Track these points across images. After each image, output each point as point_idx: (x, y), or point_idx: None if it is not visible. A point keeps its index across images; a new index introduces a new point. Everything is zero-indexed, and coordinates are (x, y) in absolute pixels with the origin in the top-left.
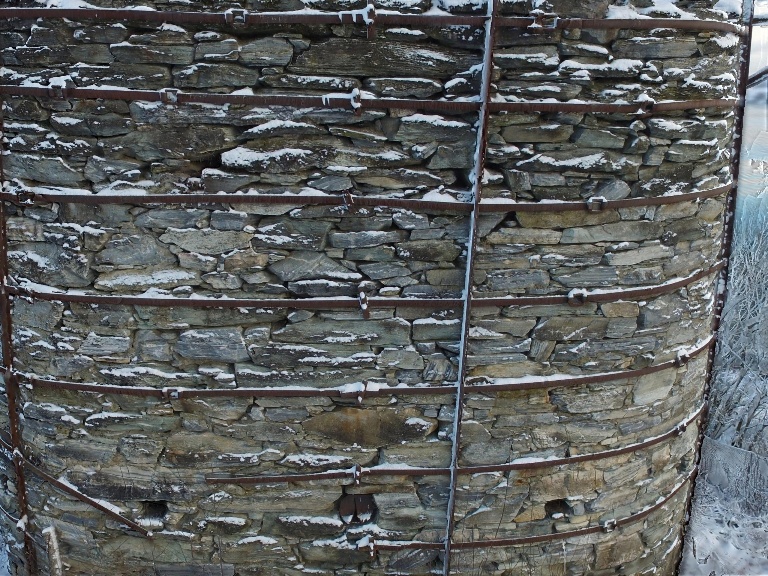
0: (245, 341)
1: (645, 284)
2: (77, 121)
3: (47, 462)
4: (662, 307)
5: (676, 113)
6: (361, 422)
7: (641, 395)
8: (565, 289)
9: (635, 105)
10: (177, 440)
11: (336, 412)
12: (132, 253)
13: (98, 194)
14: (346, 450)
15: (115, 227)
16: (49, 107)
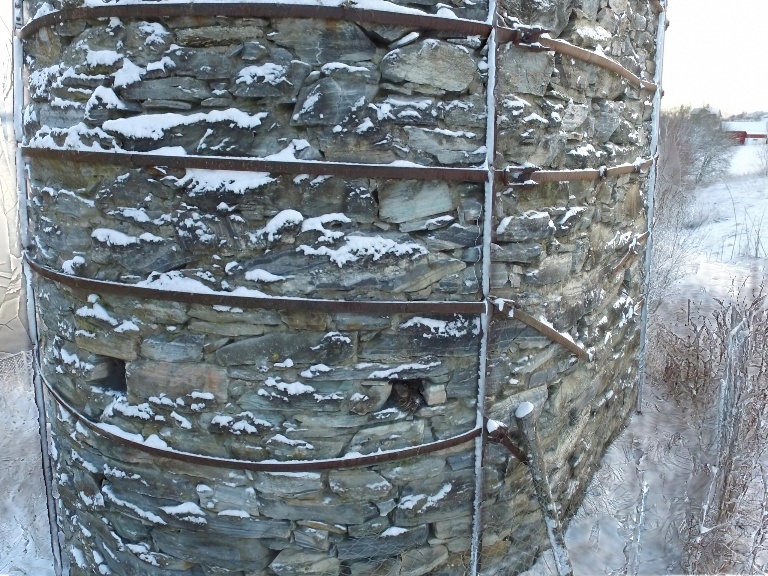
0: None
1: None
2: None
3: (528, 302)
4: None
5: None
6: None
7: None
8: (659, 85)
9: None
10: (593, 235)
11: None
12: None
13: None
14: None
15: None
16: None
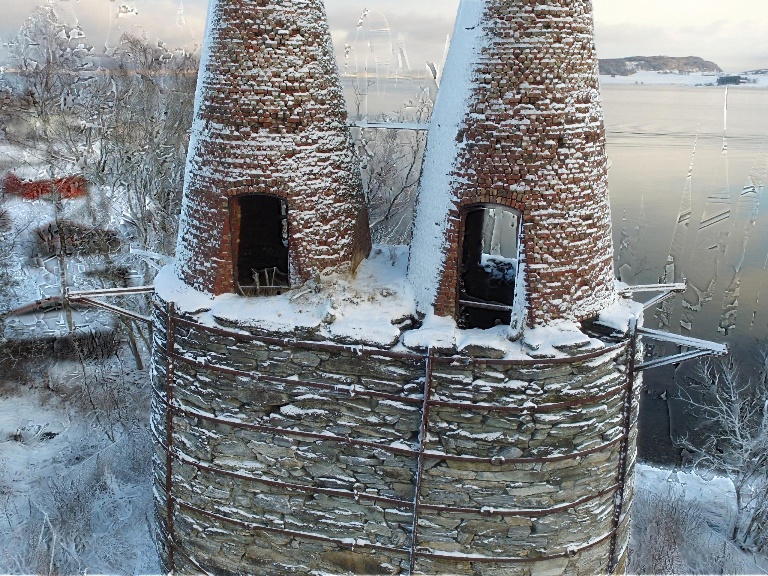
0: (290, 505)
1: (536, 507)
2: (209, 380)
3: (185, 546)
4: (551, 521)
5: (556, 409)
6: (354, 560)
7: (537, 573)
8: (479, 505)
9: (522, 408)
10: (252, 550)
11: (340, 552)
12: (233, 449)
13: (217, 418)
14: (345, 574)
15: (225, 435)
16: (196, 370)
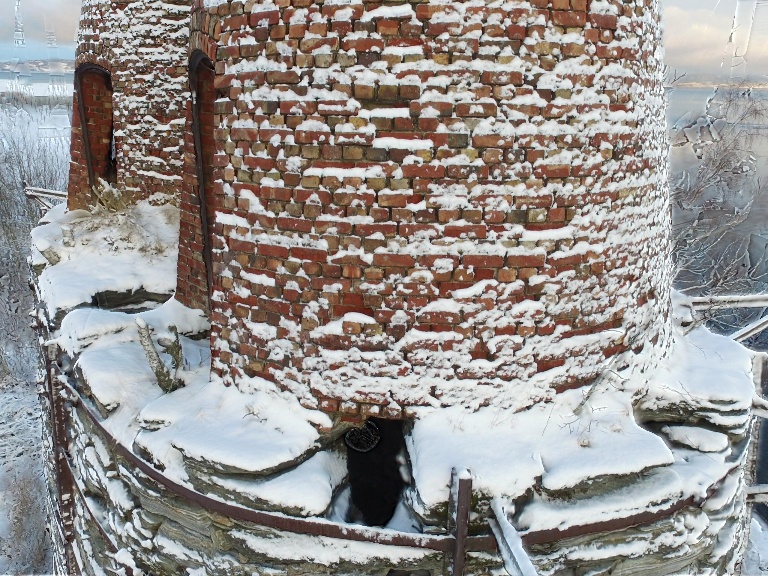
0: None
1: None
2: None
3: None
4: None
5: None
6: None
7: None
8: None
9: None
10: None
11: None
12: None
13: None
14: None
15: None
16: None
